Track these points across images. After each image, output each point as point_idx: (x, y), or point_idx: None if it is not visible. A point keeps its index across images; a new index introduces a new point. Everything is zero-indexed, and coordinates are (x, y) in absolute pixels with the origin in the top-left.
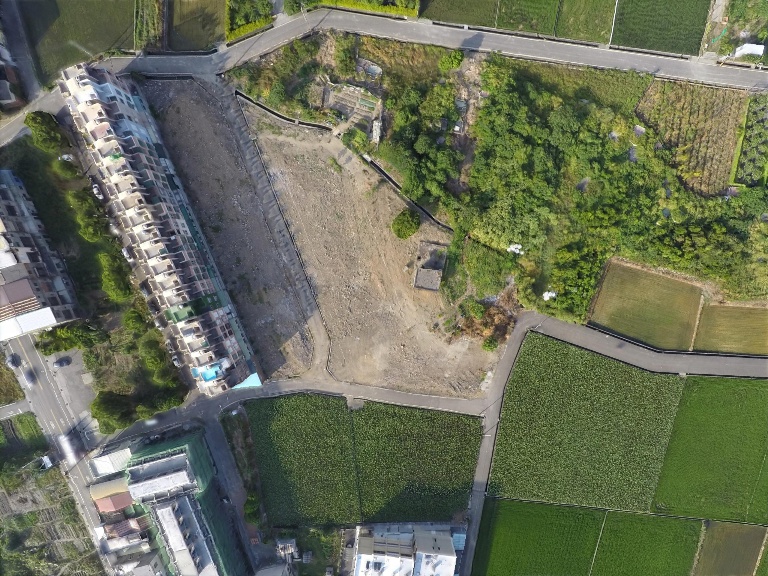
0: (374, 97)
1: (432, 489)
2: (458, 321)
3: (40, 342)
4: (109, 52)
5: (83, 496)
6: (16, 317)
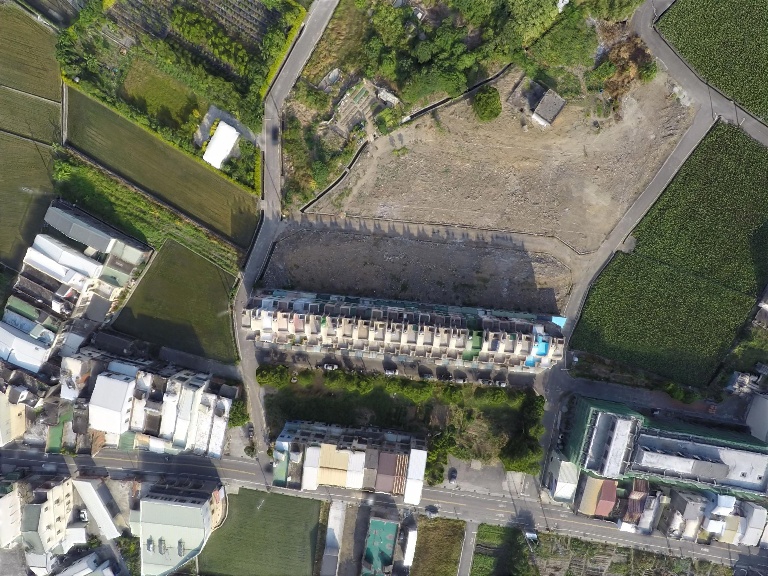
0: (359, 85)
1: (766, 209)
2: (604, 99)
3: (429, 481)
4: (230, 298)
5: (576, 530)
6: (408, 478)
